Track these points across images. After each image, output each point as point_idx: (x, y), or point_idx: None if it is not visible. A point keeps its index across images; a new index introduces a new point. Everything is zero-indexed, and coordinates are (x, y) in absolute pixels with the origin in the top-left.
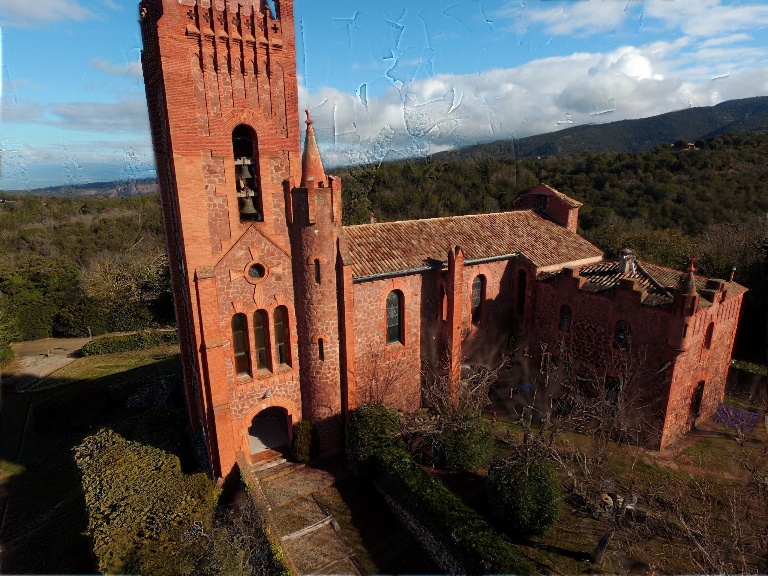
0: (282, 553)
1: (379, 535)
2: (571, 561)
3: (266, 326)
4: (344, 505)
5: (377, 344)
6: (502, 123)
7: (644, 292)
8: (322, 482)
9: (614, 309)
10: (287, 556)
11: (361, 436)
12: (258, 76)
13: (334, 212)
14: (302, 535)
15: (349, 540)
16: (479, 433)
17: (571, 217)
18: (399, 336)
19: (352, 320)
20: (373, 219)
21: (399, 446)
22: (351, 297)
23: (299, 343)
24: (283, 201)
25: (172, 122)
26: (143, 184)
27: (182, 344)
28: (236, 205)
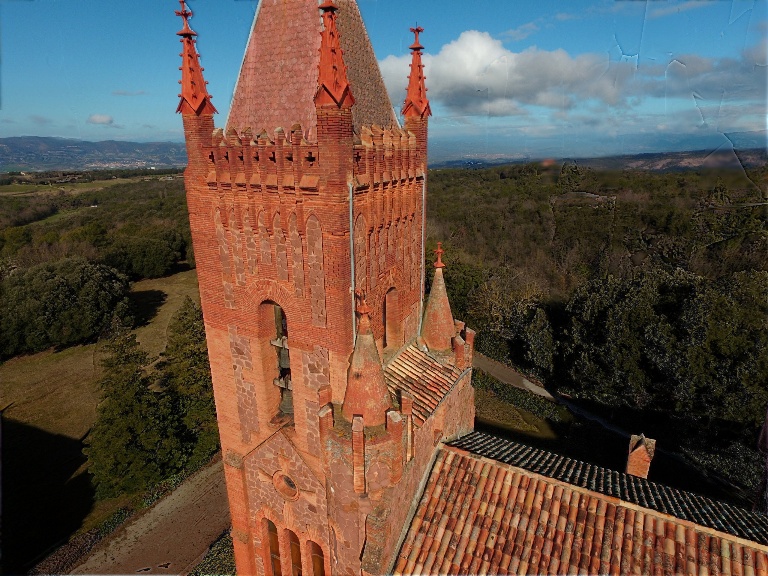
0: None
1: None
2: None
3: None
4: None
5: None
6: None
7: None
8: None
9: None
10: None
11: None
12: (286, 235)
13: (356, 479)
14: None
15: None
16: None
17: None
18: None
19: None
20: None
21: None
22: None
23: None
24: None
25: (202, 288)
26: (562, 206)
27: None
28: (264, 398)
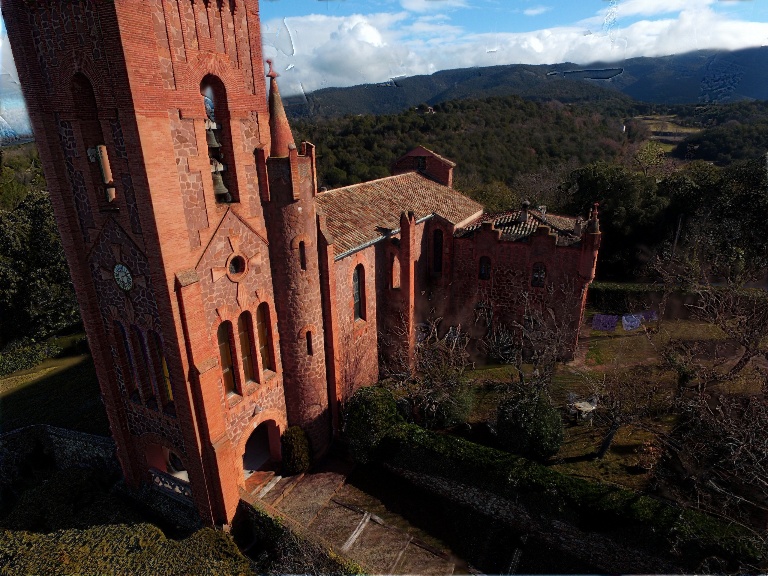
0: (362, 568)
1: (420, 510)
2: (587, 463)
3: (247, 331)
4: (370, 497)
5: (348, 325)
6: (302, 83)
7: (557, 236)
8: (334, 484)
9: (531, 253)
10: (369, 569)
11: (374, 422)
12: (222, 10)
13: (315, 185)
14: (352, 543)
15: (398, 527)
16: (467, 386)
17: (450, 176)
18: (360, 312)
19: (335, 304)
20: None
21: (402, 420)
22: (334, 279)
23: (281, 342)
24: (255, 175)
25: (130, 67)
26: None
27: (109, 380)
28: (211, 183)
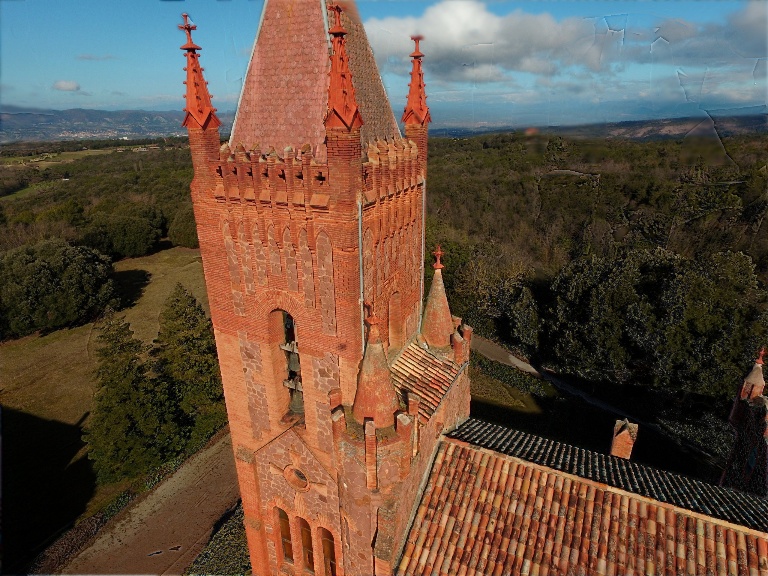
0: None
1: None
2: None
3: None
4: None
5: None
6: None
7: None
8: None
9: None
10: None
11: None
12: (296, 249)
13: (368, 476)
14: None
15: None
16: None
17: None
18: None
19: None
20: (761, 363)
21: None
22: None
23: None
24: (330, 415)
25: (211, 295)
26: (547, 184)
27: None
28: (275, 399)
